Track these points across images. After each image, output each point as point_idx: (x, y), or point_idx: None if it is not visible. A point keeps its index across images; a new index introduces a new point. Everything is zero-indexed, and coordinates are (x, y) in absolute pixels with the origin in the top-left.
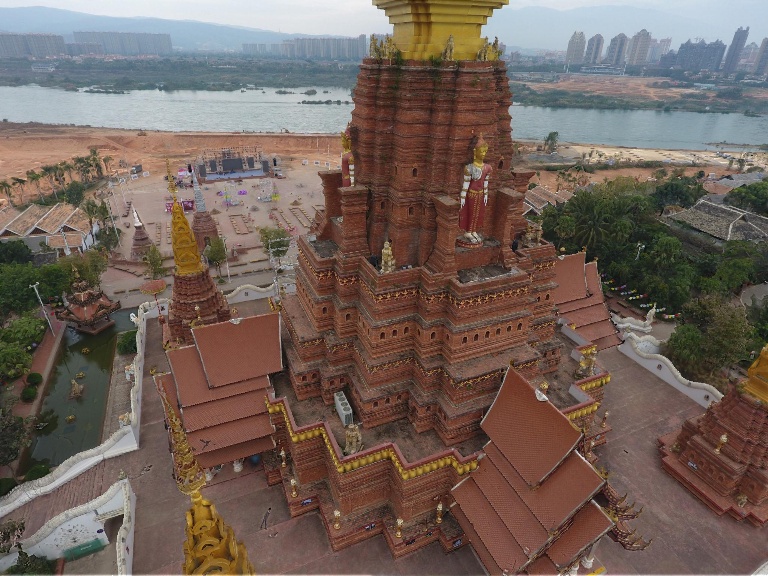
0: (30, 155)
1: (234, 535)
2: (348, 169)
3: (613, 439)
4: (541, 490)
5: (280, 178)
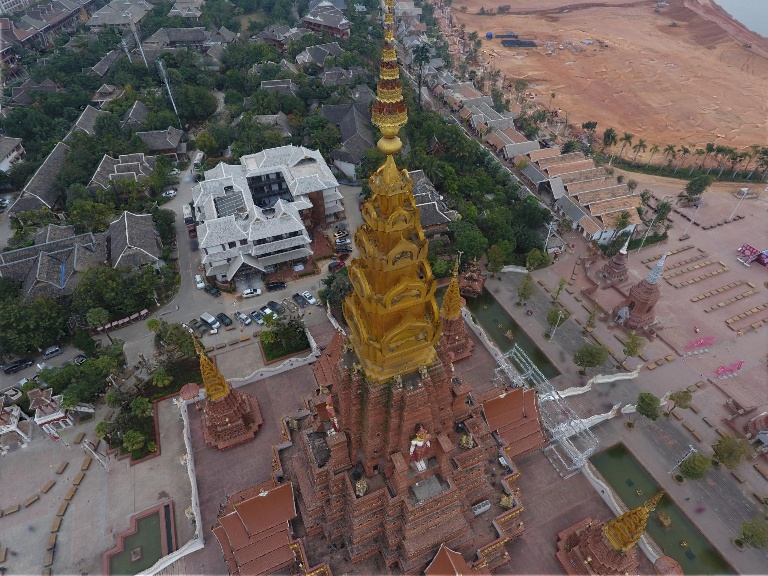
0: None
1: None
2: None
3: None
4: None
5: None
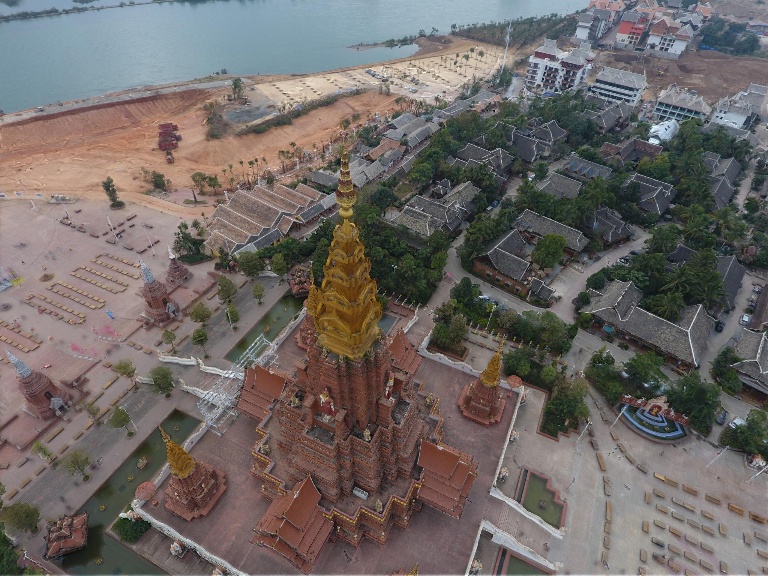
0: None
1: None
2: (329, 403)
3: (442, 414)
4: (452, 478)
5: None
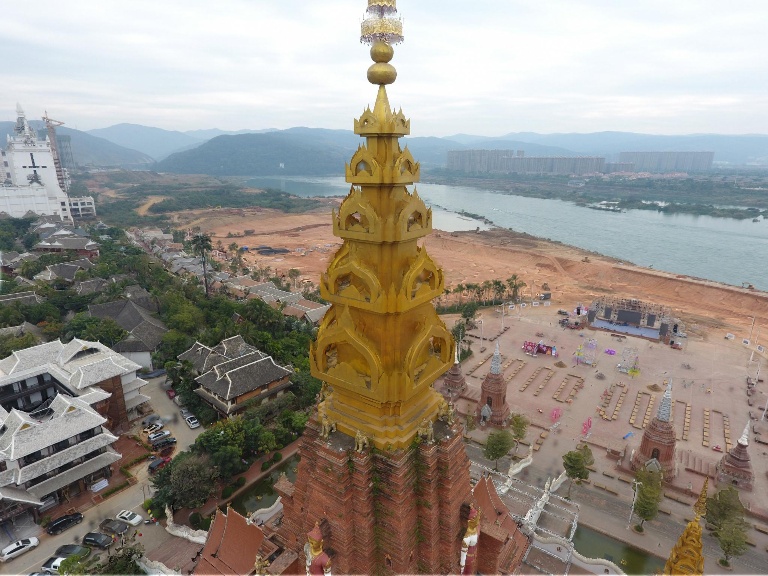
0: (494, 263)
1: None
2: None
3: None
4: None
5: (674, 348)
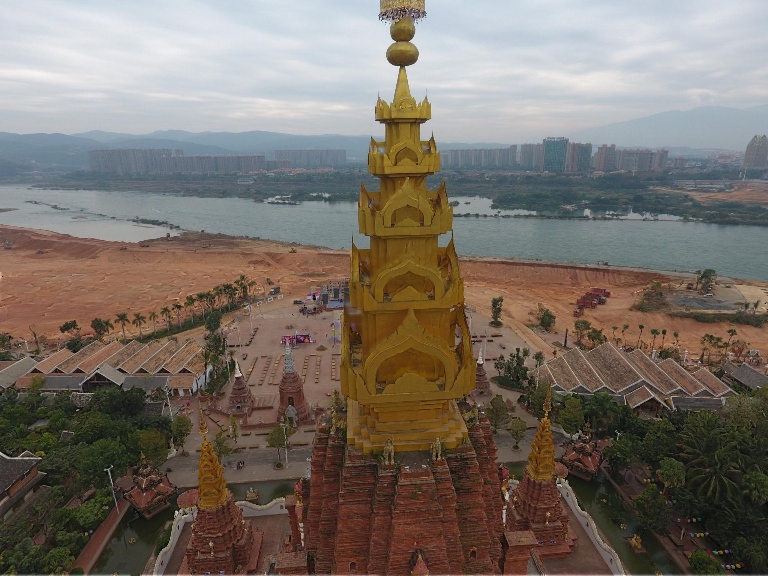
0: (205, 268)
1: None
2: None
3: None
4: None
5: None
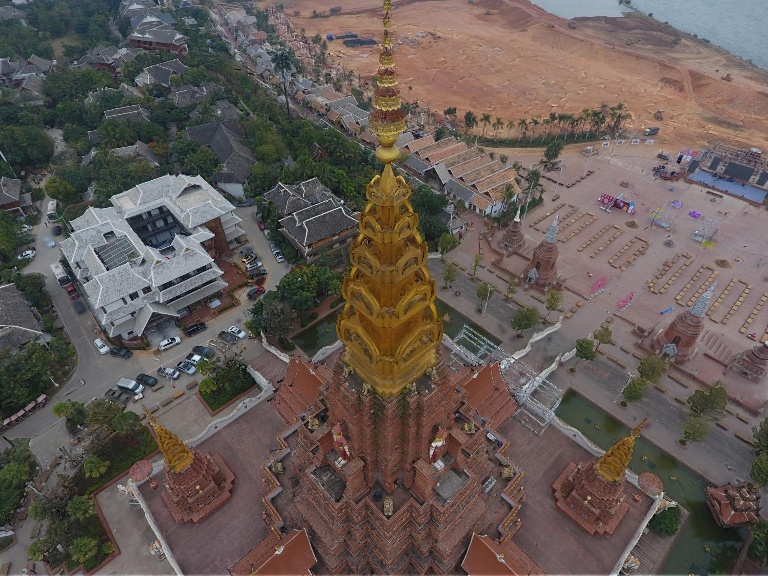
0: (609, 73)
1: (173, 442)
2: None
3: None
4: None
5: None
